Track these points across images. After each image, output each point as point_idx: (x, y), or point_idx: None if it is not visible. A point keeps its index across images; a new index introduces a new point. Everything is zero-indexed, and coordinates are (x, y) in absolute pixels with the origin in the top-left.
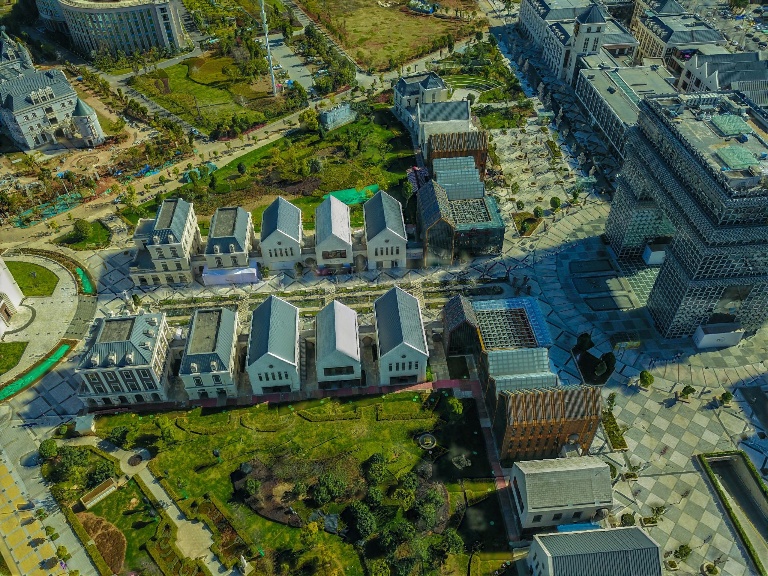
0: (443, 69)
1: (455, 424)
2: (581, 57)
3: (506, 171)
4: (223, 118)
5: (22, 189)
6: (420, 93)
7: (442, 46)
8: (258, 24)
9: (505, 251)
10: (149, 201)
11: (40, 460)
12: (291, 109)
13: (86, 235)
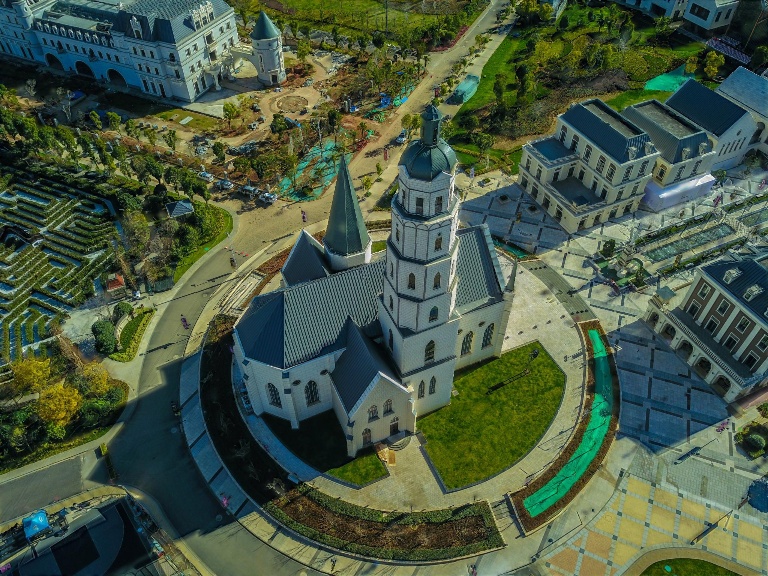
0: None
1: None
2: None
3: None
4: (440, 19)
5: (242, 153)
6: None
7: None
8: None
9: None
10: None
11: None
12: (478, 6)
13: None
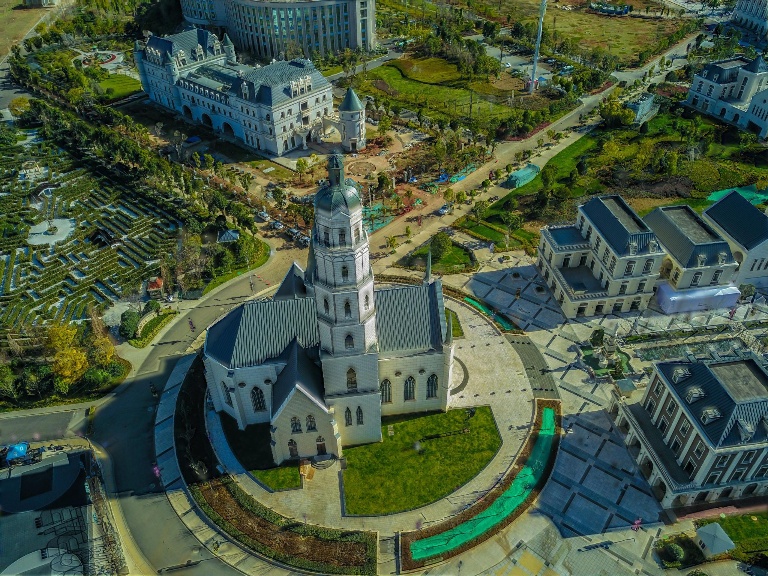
0: (706, 62)
1: None
2: None
3: None
4: (518, 112)
5: (302, 202)
6: (738, 80)
7: (675, 42)
8: (440, 27)
9: None
10: None
11: None
12: (568, 105)
13: (447, 254)
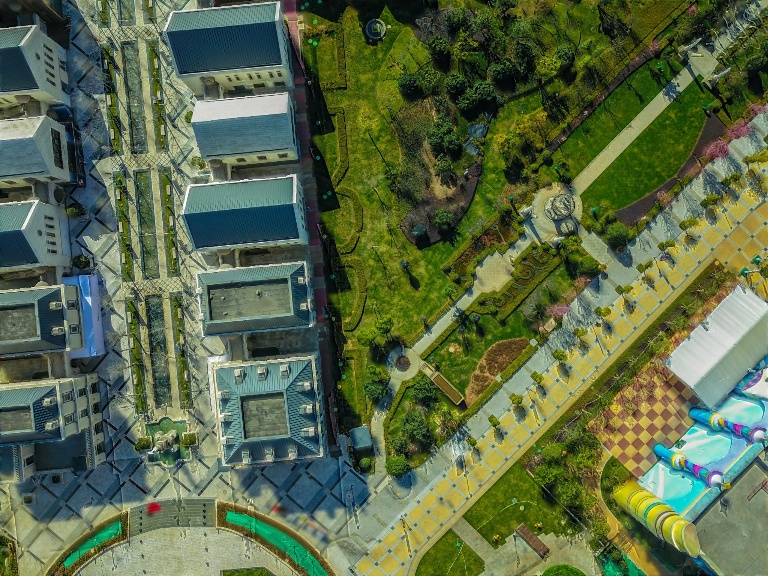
0: None
1: None
2: None
3: None
4: None
5: None
6: None
7: None
8: None
9: None
10: None
11: (404, 475)
12: None
13: None
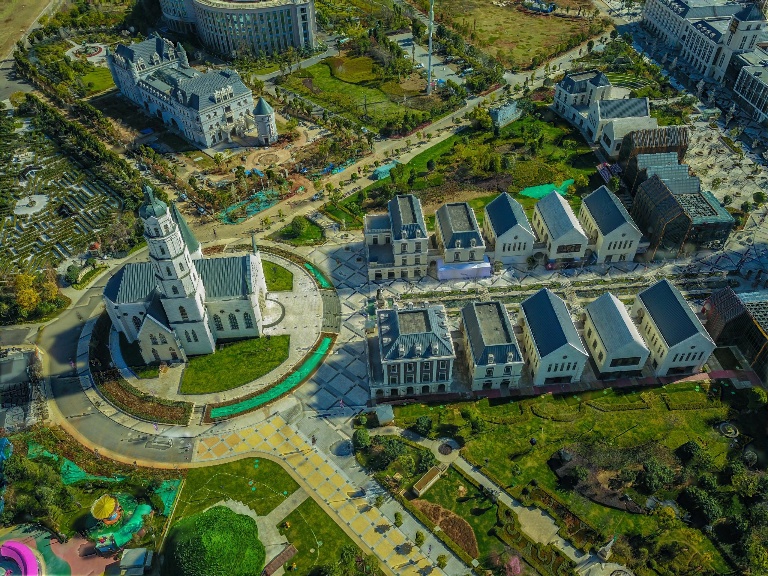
0: (588, 67)
1: (751, 413)
2: (738, 54)
3: (692, 167)
4: (398, 116)
5: (215, 187)
6: (587, 91)
7: (576, 45)
8: None
9: (724, 245)
10: (347, 198)
11: (351, 449)
12: (452, 107)
13: (302, 231)
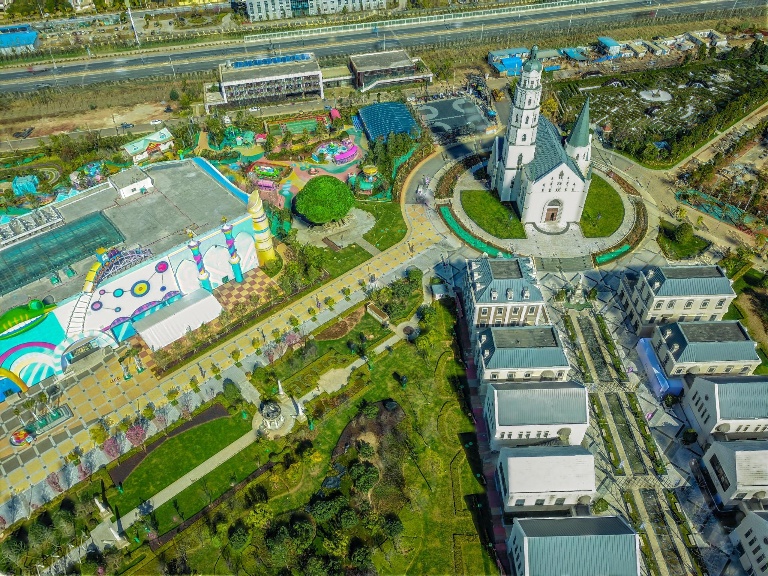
0: None
1: None
2: None
3: None
4: None
5: (735, 181)
6: None
7: None
8: None
9: None
10: None
11: None
12: None
13: (677, 238)
